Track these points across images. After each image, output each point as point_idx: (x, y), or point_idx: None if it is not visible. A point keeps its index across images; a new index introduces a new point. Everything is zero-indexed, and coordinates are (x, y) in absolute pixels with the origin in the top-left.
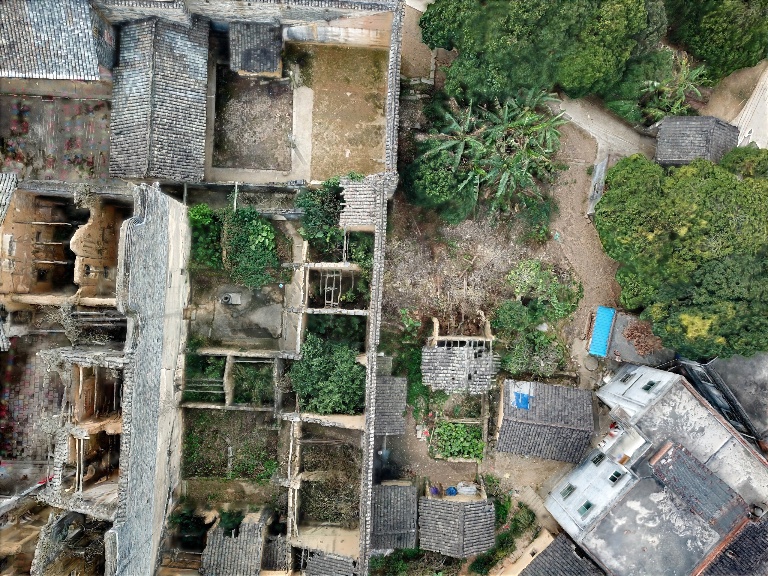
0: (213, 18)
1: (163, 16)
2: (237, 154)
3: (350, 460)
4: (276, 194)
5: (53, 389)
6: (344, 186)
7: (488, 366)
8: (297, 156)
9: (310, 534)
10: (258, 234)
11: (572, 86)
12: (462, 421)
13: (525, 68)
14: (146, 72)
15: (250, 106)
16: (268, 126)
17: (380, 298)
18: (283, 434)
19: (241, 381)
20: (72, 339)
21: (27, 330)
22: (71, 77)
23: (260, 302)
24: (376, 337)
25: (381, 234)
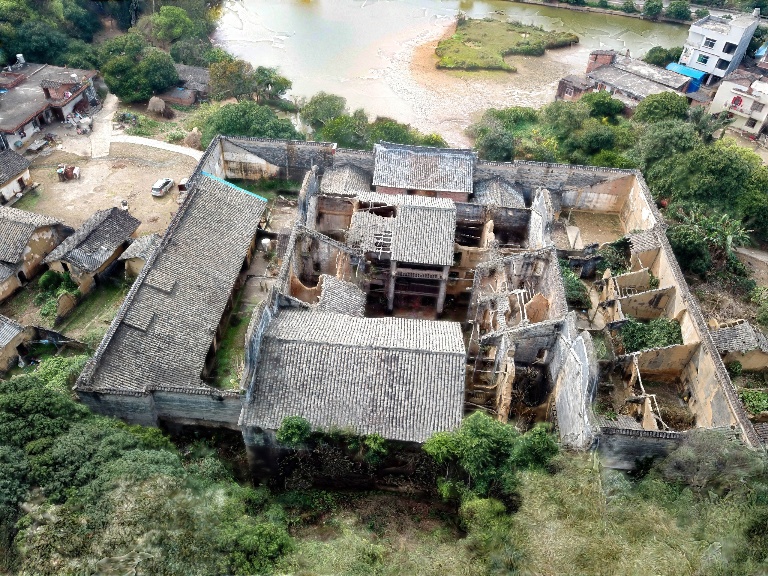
0: (524, 185)
1: (503, 176)
2: None
3: None
4: None
5: None
6: (630, 237)
7: (765, 342)
8: None
9: None
10: None
11: (745, 215)
12: (759, 389)
13: (715, 202)
14: (495, 195)
15: None
16: None
17: (681, 273)
18: (614, 394)
19: None
20: None
21: (448, 277)
22: (457, 191)
23: None
24: (688, 290)
25: (669, 245)
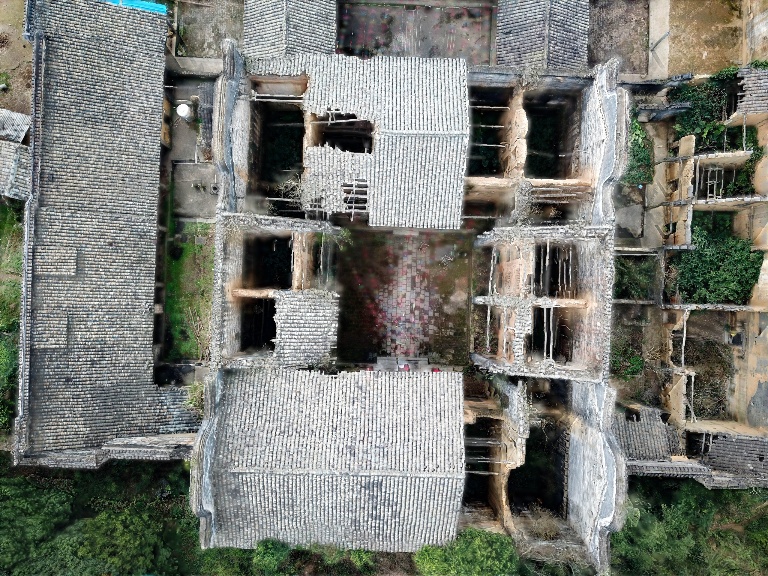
0: None
1: None
2: (594, 59)
3: (719, 355)
4: (636, 96)
5: (424, 288)
6: (744, 76)
7: None
8: (654, 59)
9: (695, 423)
10: (631, 132)
11: None
12: None
13: None
14: None
15: (606, 11)
16: (624, 31)
17: None
18: (648, 331)
19: (620, 275)
20: (524, 216)
21: None
22: None
23: (621, 203)
24: None
25: None
